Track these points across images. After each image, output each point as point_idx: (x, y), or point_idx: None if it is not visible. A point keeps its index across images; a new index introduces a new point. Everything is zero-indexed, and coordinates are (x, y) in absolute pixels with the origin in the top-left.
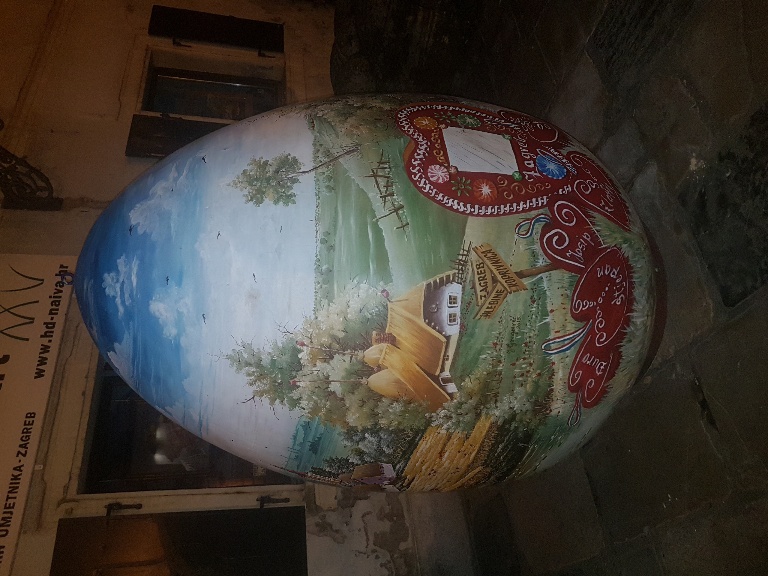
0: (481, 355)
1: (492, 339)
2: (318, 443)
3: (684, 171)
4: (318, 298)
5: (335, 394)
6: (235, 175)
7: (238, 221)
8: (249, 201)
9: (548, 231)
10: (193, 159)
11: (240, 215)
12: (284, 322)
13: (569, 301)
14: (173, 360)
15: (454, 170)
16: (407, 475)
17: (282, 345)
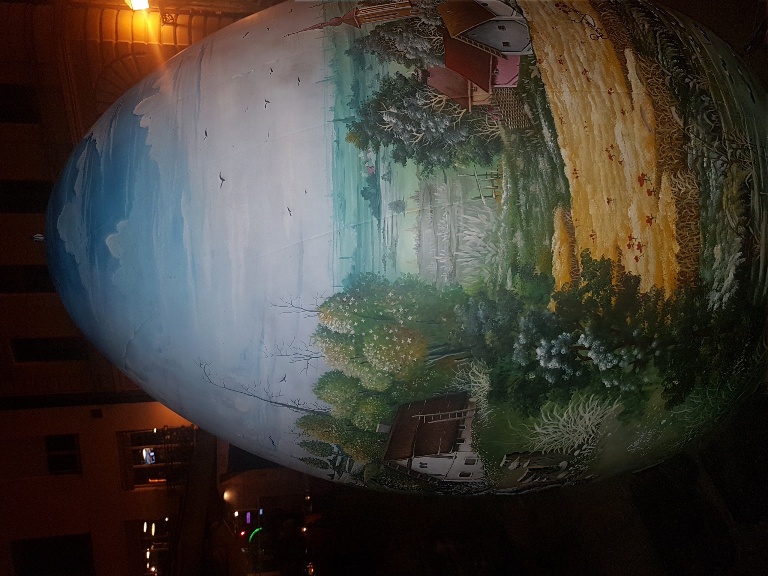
0: None
1: None
2: None
3: None
4: None
5: None
6: None
7: None
8: None
9: None
10: None
11: None
12: None
13: None
14: None
15: None
16: None
17: None
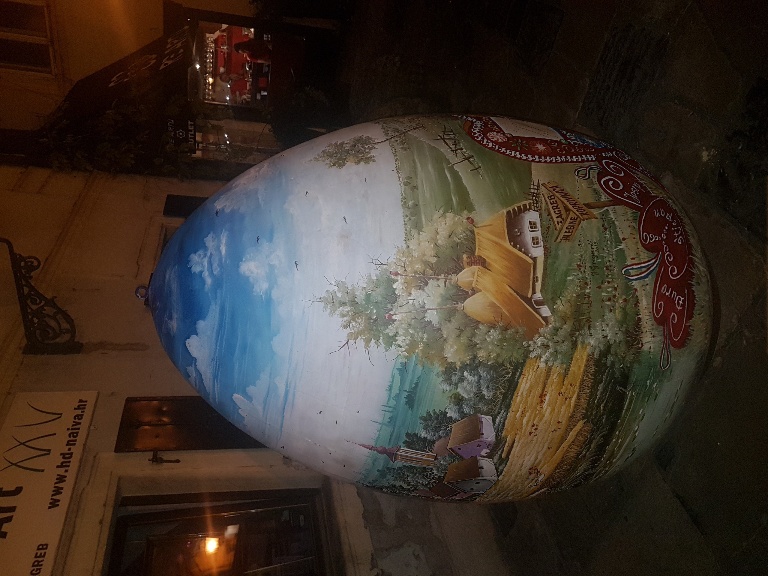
0: (568, 276)
1: (575, 261)
2: (415, 391)
3: (699, 165)
4: (408, 229)
5: (432, 324)
6: (315, 154)
7: (324, 181)
8: (332, 166)
9: (603, 177)
10: (271, 158)
11: (325, 176)
12: (377, 255)
13: (637, 232)
14: (263, 318)
15: (510, 135)
16: (507, 436)
17: (376, 278)
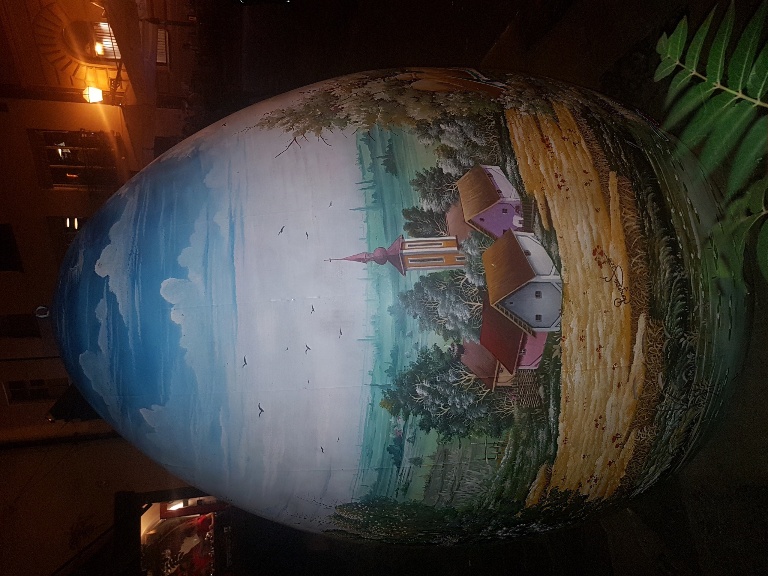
0: None
1: None
2: (392, 155)
3: None
4: None
5: (384, 100)
6: None
7: None
8: None
9: None
10: None
11: None
12: None
13: None
14: (191, 169)
15: None
16: (532, 192)
17: None
